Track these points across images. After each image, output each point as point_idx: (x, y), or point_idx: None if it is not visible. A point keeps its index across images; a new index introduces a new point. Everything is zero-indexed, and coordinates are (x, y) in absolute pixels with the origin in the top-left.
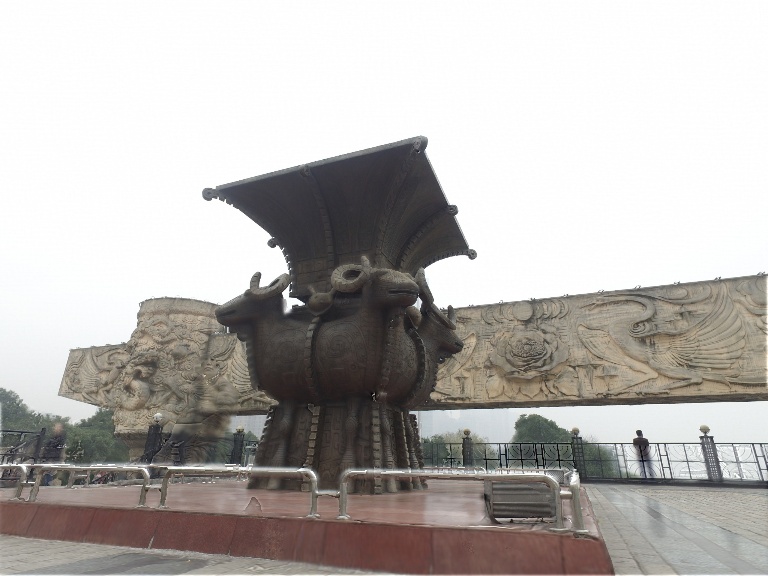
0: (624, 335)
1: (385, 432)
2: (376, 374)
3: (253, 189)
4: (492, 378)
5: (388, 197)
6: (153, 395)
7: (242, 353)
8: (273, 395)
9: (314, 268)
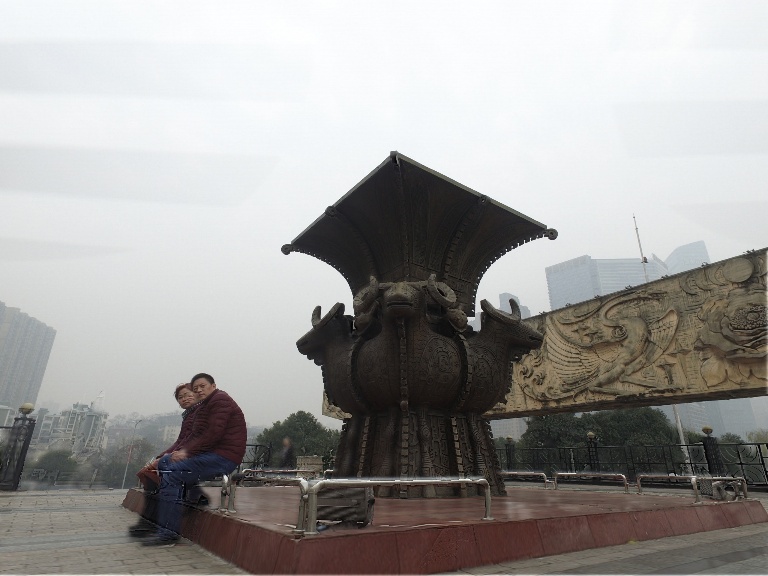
0: None
1: (422, 439)
2: (398, 384)
3: (312, 236)
4: (707, 361)
5: (400, 212)
6: None
7: None
8: (344, 409)
9: None
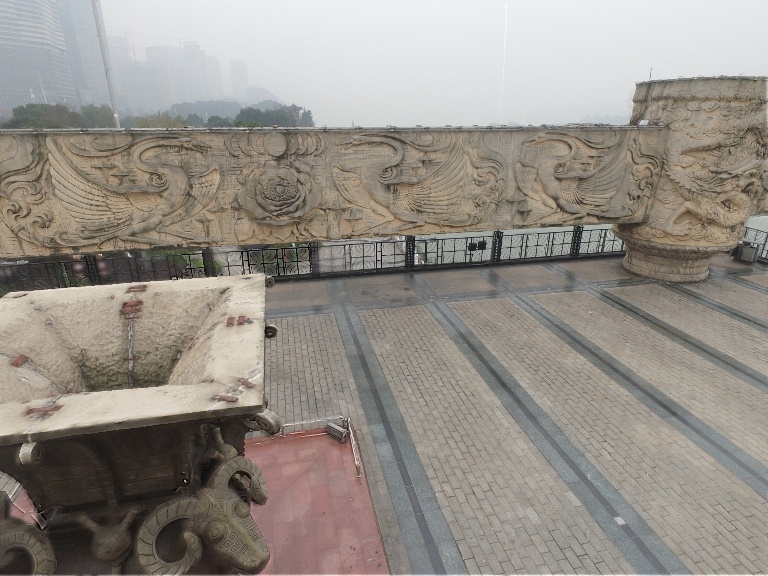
0: (374, 181)
1: None
2: None
3: None
4: (241, 221)
5: None
6: None
7: None
8: None
9: (72, 475)
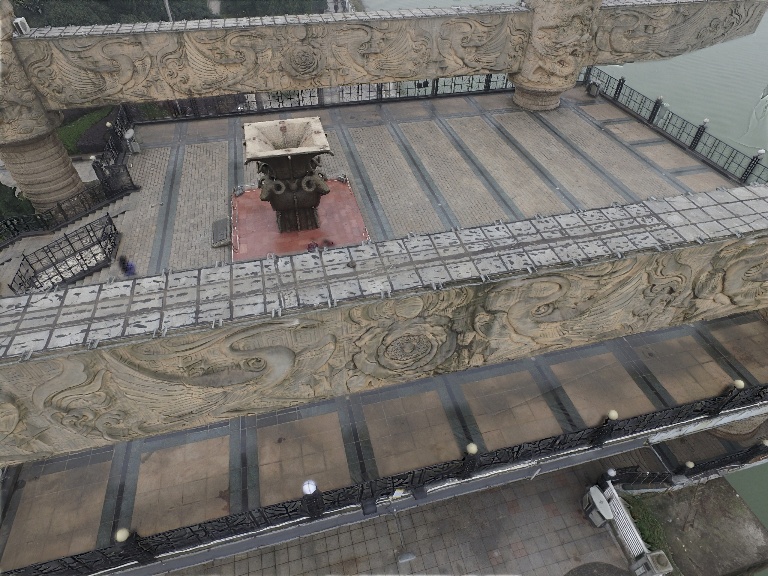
0: (355, 52)
1: None
2: (315, 204)
3: None
4: (284, 78)
5: None
6: (4, 112)
7: (66, 60)
8: None
9: (283, 170)
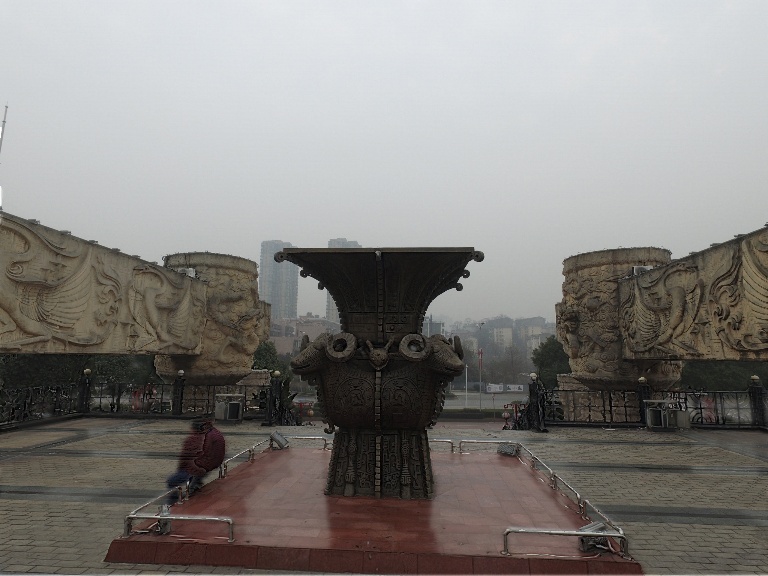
0: None
1: (348, 453)
2: None
3: None
4: None
5: None
6: (582, 345)
7: (640, 298)
8: None
9: None
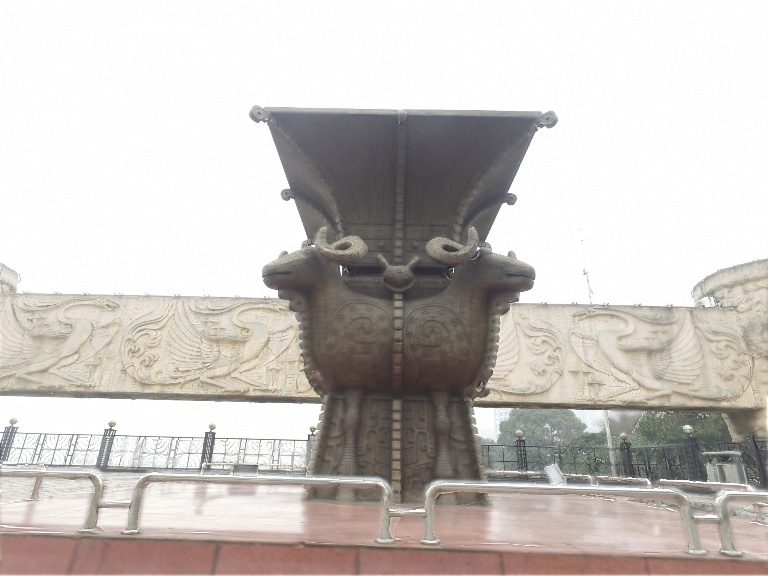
0: None
1: None
2: None
3: None
4: None
5: None
6: None
7: None
8: None
9: None
